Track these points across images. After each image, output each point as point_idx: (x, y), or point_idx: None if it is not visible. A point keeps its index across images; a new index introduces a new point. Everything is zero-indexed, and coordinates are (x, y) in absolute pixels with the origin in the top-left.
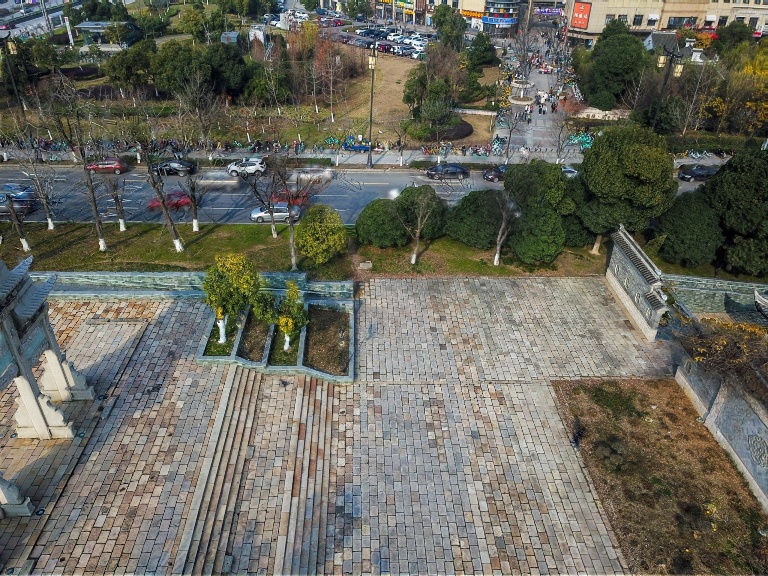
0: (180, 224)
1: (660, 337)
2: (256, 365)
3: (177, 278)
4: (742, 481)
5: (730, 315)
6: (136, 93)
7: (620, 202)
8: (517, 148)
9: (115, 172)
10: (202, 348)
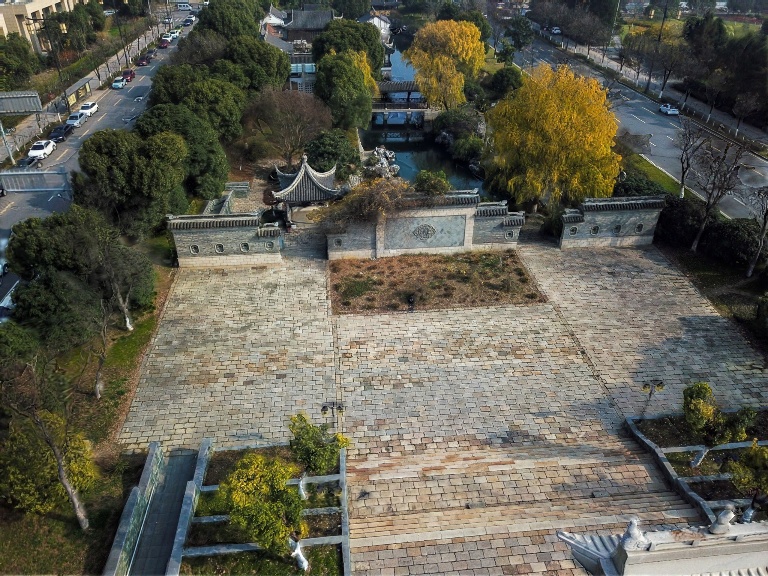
0: None
1: None
2: None
3: None
4: (424, 256)
5: None
6: None
7: None
8: None
9: None
10: None
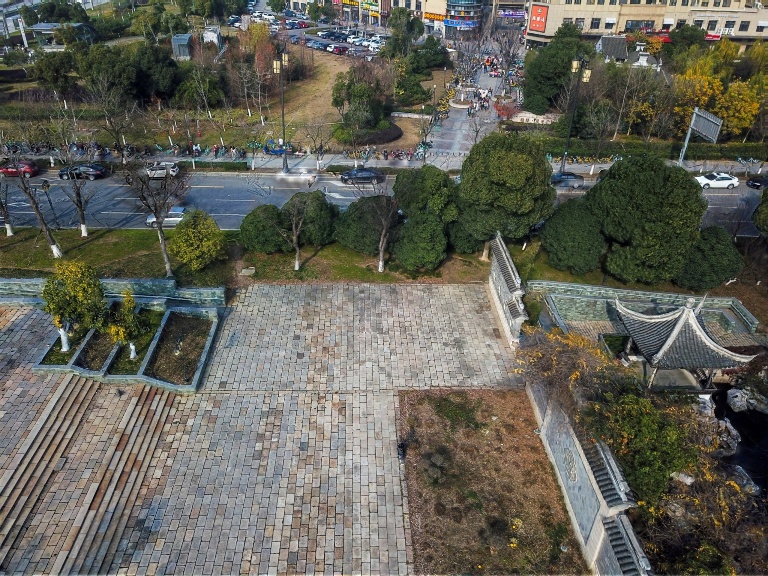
0: (72, 229)
1: None
2: (93, 374)
3: (43, 284)
4: (559, 495)
5: (613, 323)
6: (46, 96)
7: (495, 209)
8: (441, 152)
9: (25, 176)
10: (41, 357)
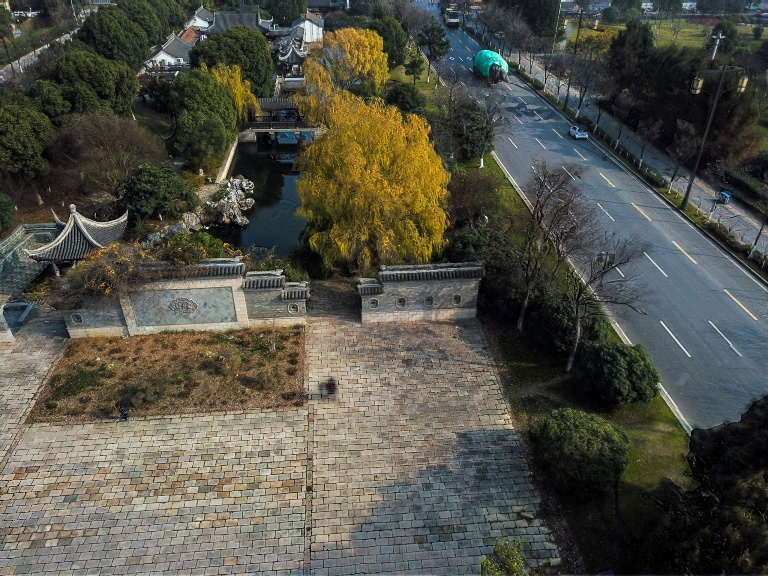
0: None
1: (13, 333)
2: None
3: None
4: (190, 333)
5: None
6: None
7: None
8: None
9: None
10: None
